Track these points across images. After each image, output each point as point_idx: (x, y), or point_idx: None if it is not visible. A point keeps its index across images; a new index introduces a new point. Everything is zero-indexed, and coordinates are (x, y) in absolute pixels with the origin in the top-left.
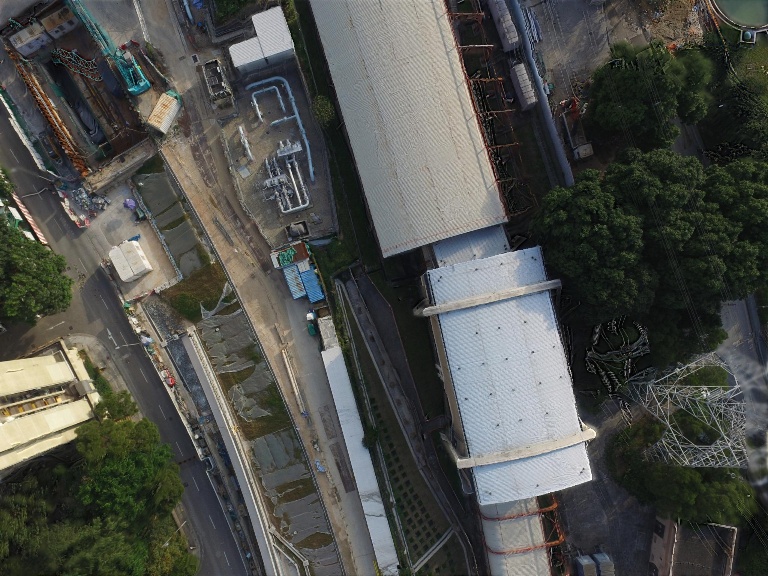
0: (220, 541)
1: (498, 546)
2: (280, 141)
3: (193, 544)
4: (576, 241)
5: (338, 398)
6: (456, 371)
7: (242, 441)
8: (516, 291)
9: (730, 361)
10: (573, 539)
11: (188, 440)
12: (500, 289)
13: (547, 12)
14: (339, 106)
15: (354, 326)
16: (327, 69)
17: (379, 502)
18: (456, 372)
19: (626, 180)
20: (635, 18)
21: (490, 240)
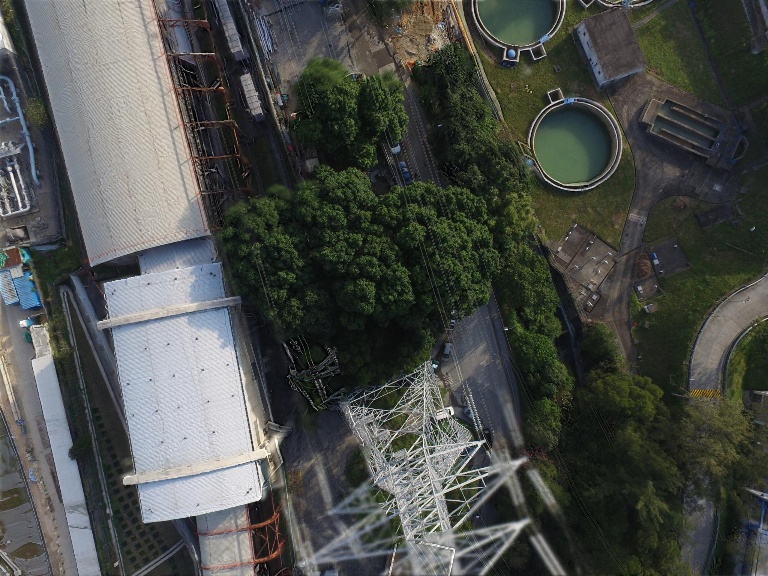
0: None
1: (206, 561)
2: (2, 143)
3: None
4: (238, 259)
5: (47, 407)
6: (125, 386)
7: None
8: (186, 307)
9: (479, 381)
10: (309, 554)
11: None
12: (172, 305)
13: (283, 22)
14: (51, 110)
15: (80, 334)
16: (41, 71)
17: (84, 514)
18: (125, 387)
19: (298, 199)
20: (377, 31)
21: (197, 253)
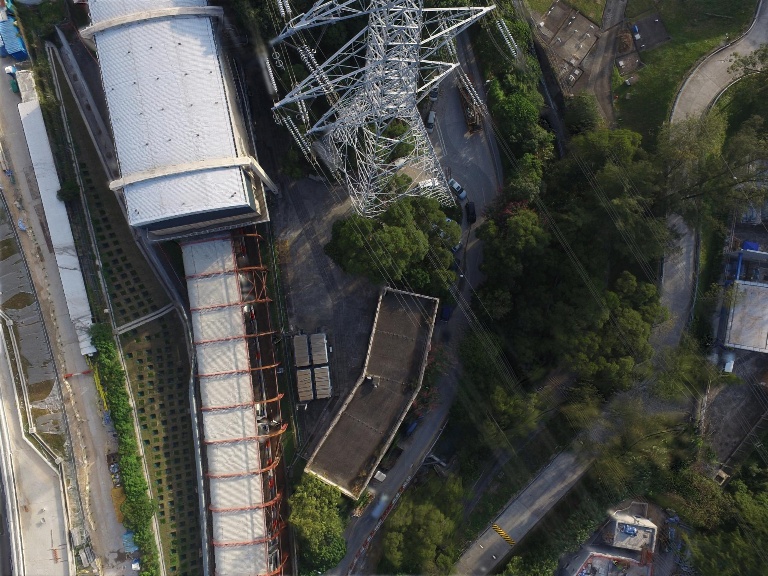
0: None
1: (194, 304)
2: None
3: None
4: None
5: (34, 151)
6: (110, 92)
7: None
8: (168, 10)
9: (463, 155)
10: (297, 321)
11: None
12: (154, 9)
13: None
14: None
15: (66, 90)
16: None
17: (74, 256)
18: (110, 93)
19: None
20: None
21: None
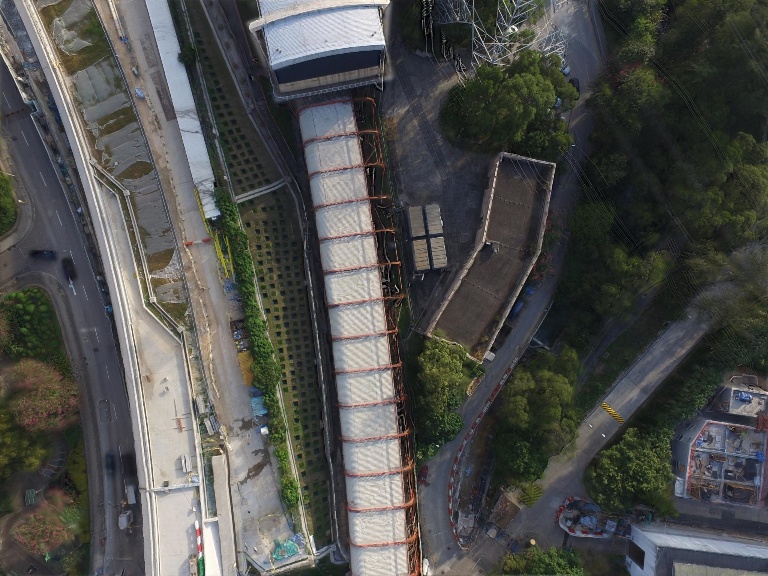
0: (52, 199)
1: (316, 167)
2: None
3: (22, 198)
4: None
5: (154, 14)
6: None
7: (64, 77)
8: None
9: (566, 31)
10: (407, 197)
11: (13, 85)
12: None
13: None
14: None
15: None
16: None
17: (195, 119)
18: None
19: None
20: None
21: None
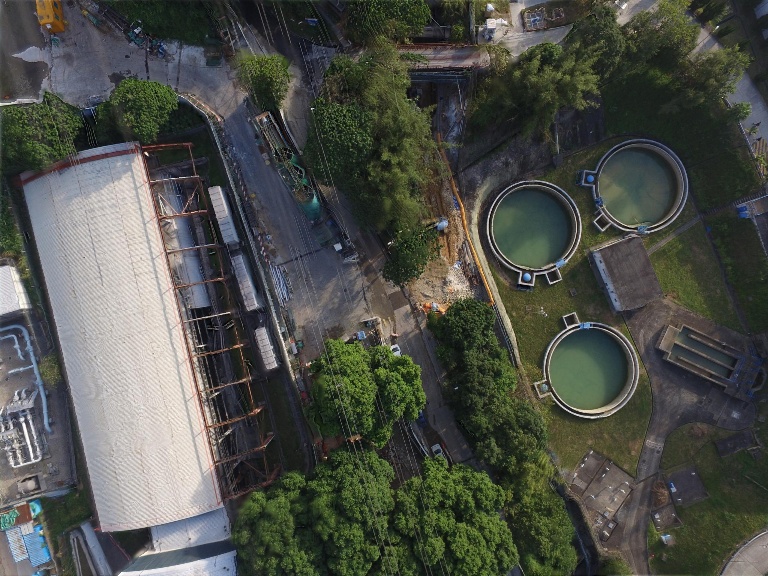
0: None
1: None
2: (15, 392)
3: None
4: (253, 570)
5: None
6: None
7: None
8: None
9: None
10: None
11: None
12: None
13: (299, 269)
14: (66, 370)
15: None
16: (56, 331)
17: None
18: None
19: (314, 502)
20: (392, 275)
21: (209, 521)
